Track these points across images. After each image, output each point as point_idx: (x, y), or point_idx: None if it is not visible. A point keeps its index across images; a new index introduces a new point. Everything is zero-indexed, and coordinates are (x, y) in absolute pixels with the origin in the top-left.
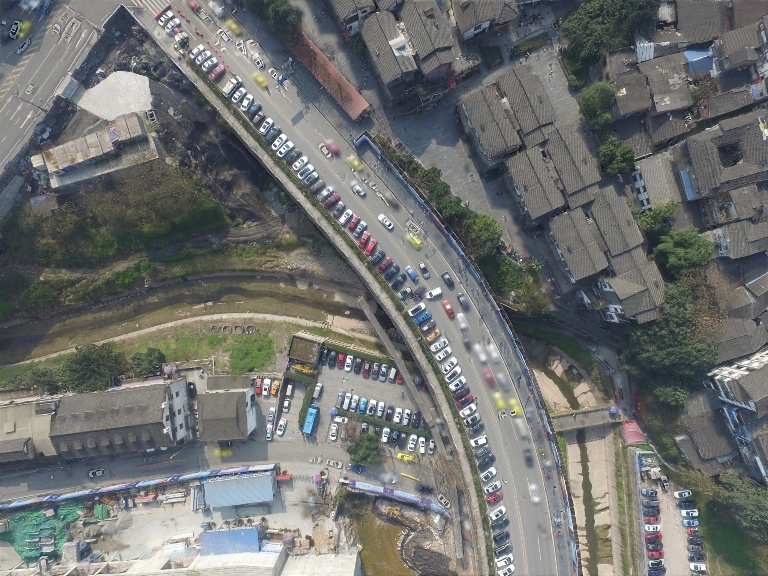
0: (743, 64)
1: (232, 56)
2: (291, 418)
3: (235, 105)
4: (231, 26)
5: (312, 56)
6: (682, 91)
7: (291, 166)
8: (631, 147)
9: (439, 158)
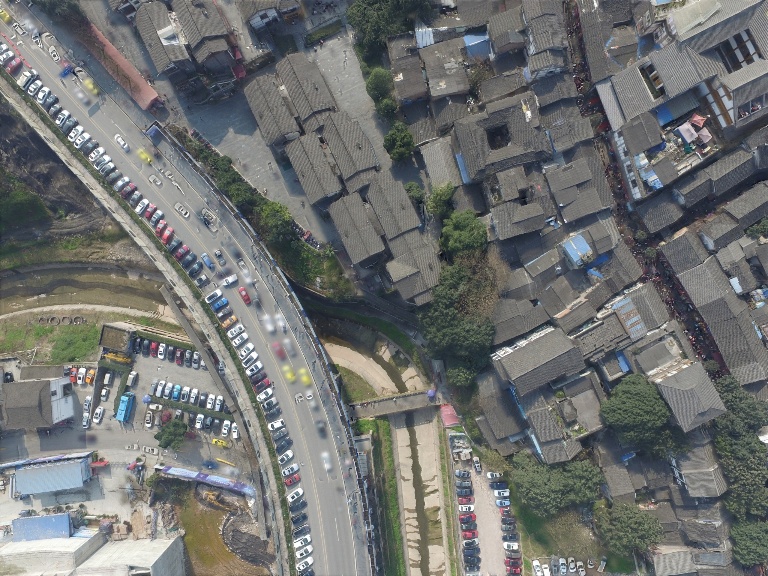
0: (513, 47)
1: (28, 49)
2: (109, 406)
3: (32, 98)
4: (27, 19)
5: (99, 47)
6: (458, 75)
7: (88, 157)
8: (416, 132)
9: (237, 147)
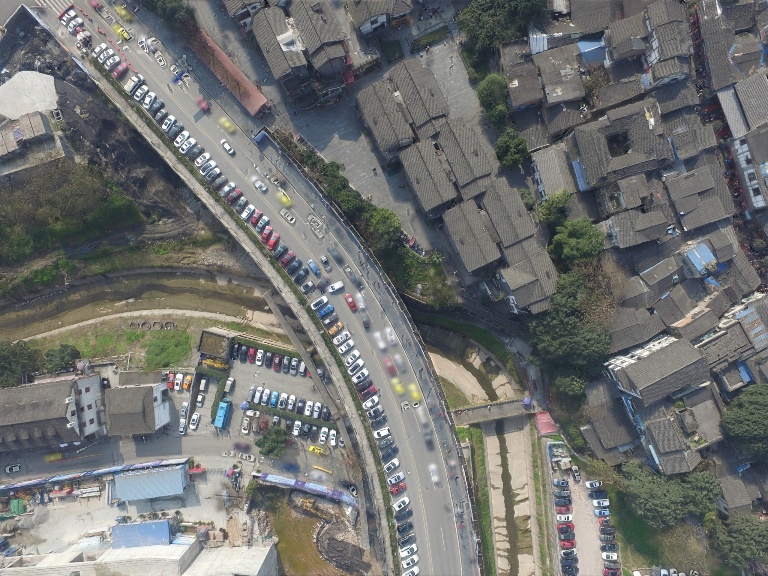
0: (632, 54)
1: (134, 54)
2: (205, 412)
3: (138, 103)
4: (133, 24)
5: (209, 53)
6: (574, 82)
7: (194, 162)
8: (527, 138)
9: (342, 152)
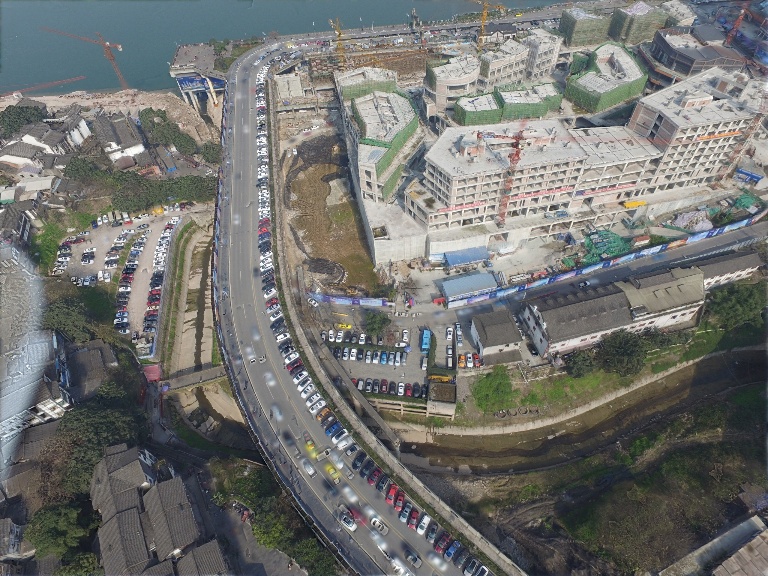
0: None
1: None
2: (444, 342)
3: None
4: None
5: None
6: None
7: None
8: None
9: None
